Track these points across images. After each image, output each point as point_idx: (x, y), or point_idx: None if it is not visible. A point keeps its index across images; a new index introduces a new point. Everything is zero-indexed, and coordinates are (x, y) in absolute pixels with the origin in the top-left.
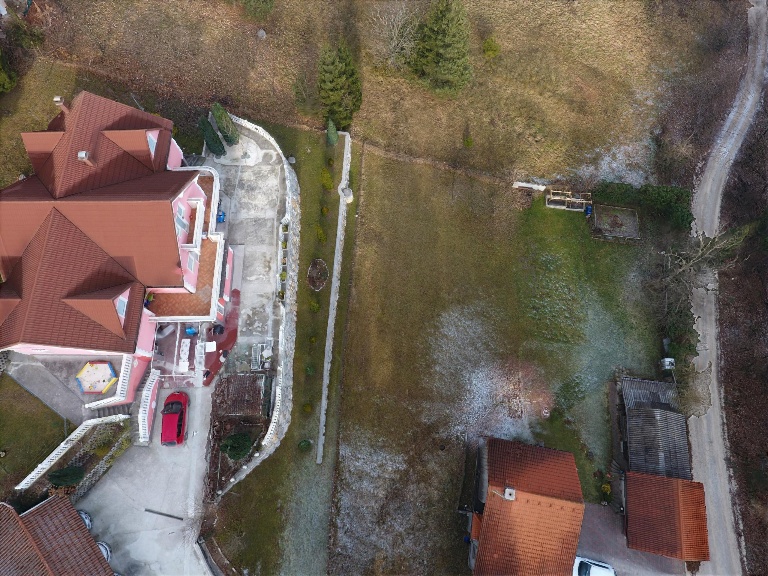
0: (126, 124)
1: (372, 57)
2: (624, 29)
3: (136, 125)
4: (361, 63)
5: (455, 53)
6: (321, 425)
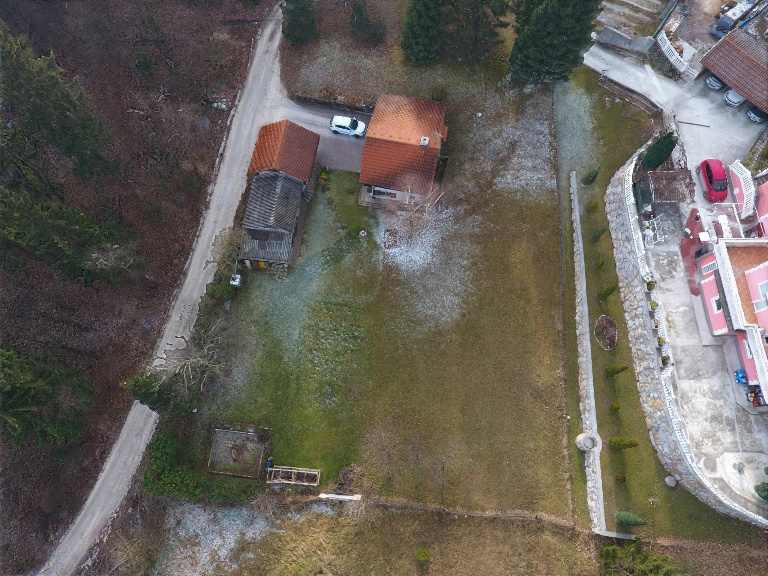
0: None
1: None
2: None
3: None
4: None
5: None
6: (577, 198)
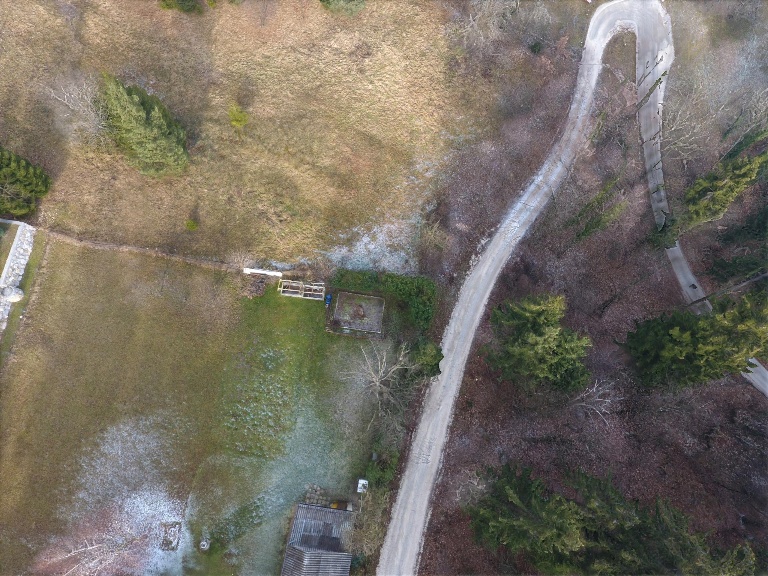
0: None
1: (86, 130)
2: (417, 91)
3: None
4: (68, 138)
5: (141, 138)
6: None
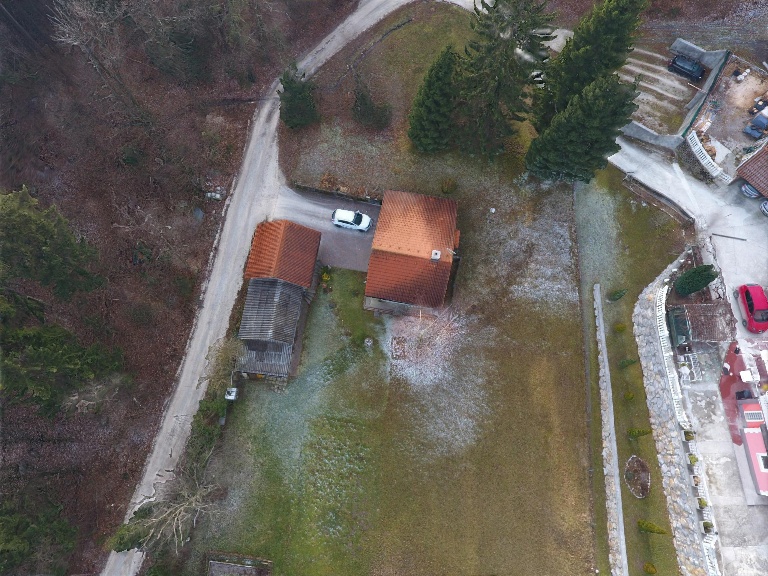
0: None
1: None
2: None
3: None
4: None
5: None
6: (601, 315)
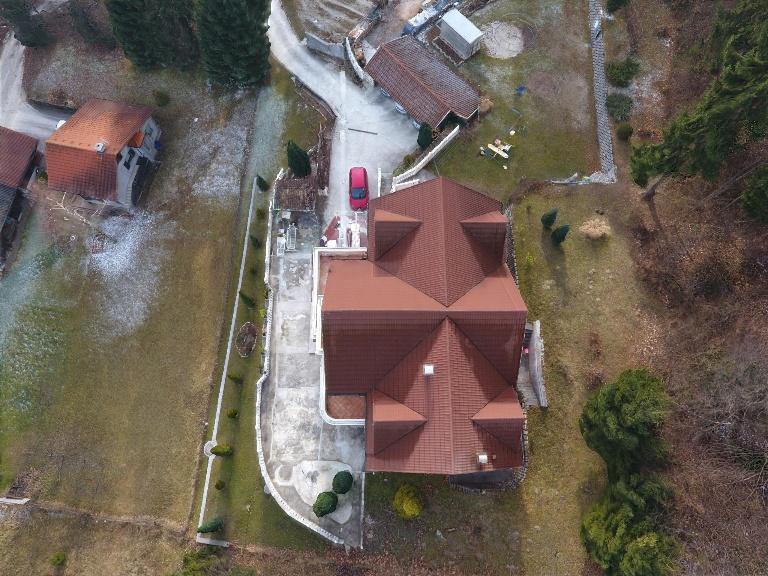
0: (407, 443)
1: None
2: None
3: (398, 447)
4: None
5: None
6: (252, 204)
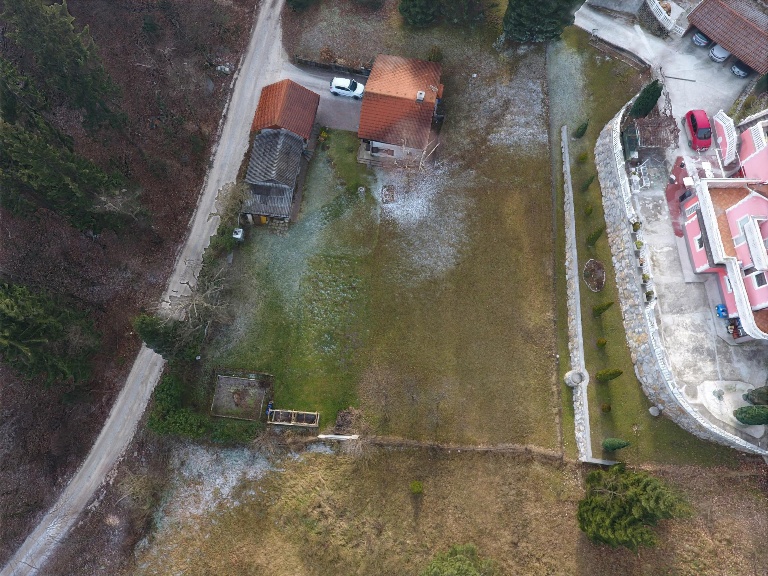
0: None
1: None
2: None
3: None
4: None
5: None
6: (567, 150)
